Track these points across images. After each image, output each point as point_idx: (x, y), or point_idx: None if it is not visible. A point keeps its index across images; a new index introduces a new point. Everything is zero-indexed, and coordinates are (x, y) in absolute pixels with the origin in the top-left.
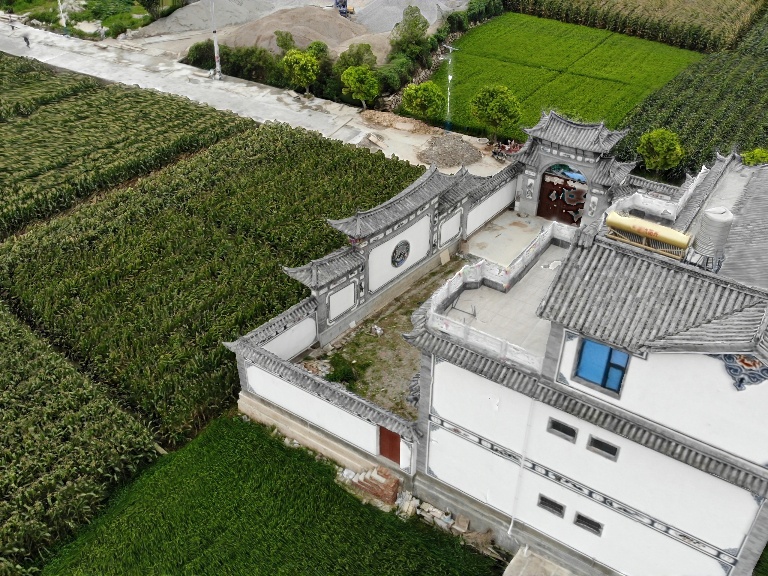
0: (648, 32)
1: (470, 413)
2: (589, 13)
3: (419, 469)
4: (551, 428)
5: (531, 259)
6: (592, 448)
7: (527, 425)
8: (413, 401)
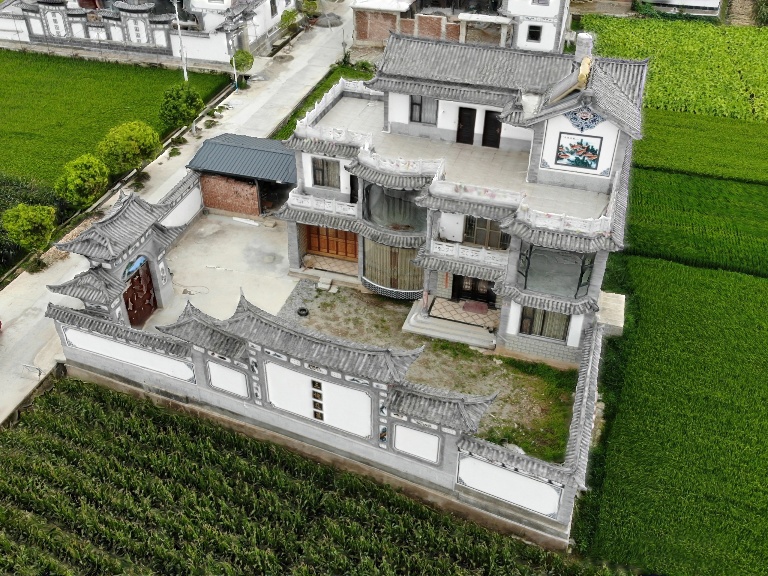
0: None
1: None
2: None
3: None
4: None
5: None
6: None
7: None
8: None
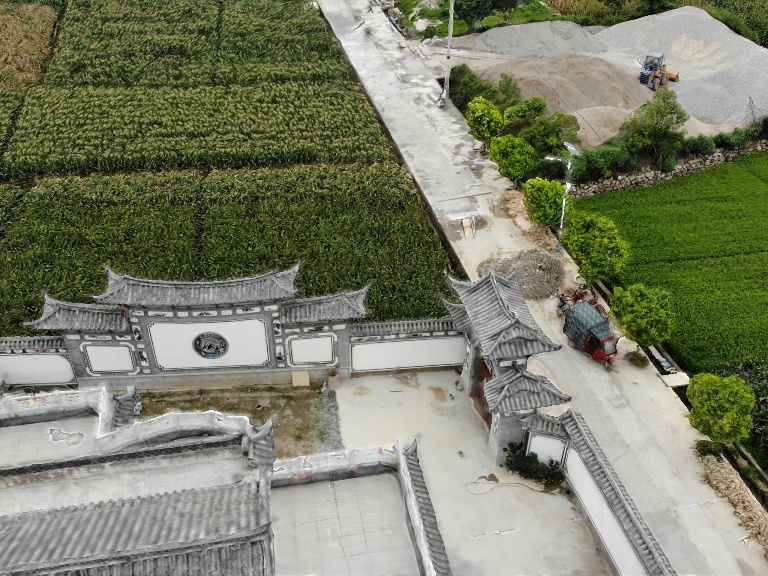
0: None
1: None
2: None
3: None
4: None
5: (34, 413)
6: None
7: None
8: None
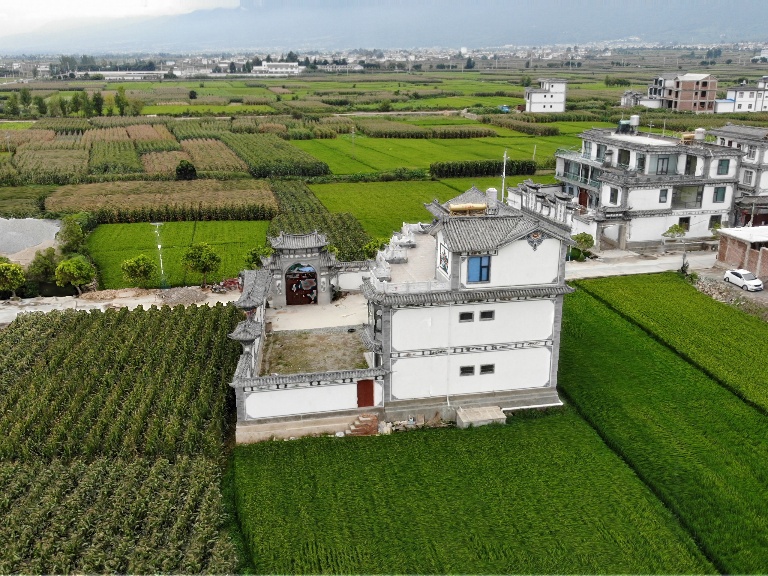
0: (220, 216)
1: (416, 337)
2: (169, 212)
3: (386, 401)
4: (460, 320)
5: None
6: (482, 319)
7: (449, 325)
8: (379, 350)
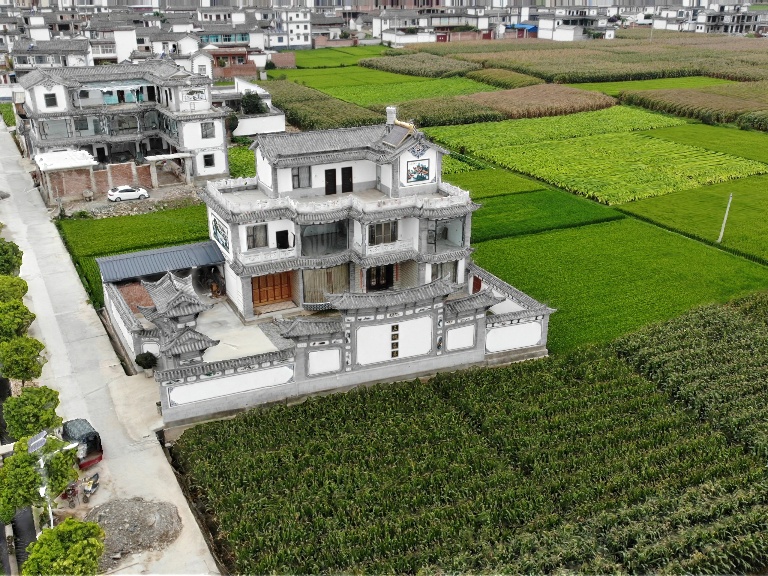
0: None
1: None
2: None
3: None
4: None
5: (391, 207)
6: None
7: None
8: None
